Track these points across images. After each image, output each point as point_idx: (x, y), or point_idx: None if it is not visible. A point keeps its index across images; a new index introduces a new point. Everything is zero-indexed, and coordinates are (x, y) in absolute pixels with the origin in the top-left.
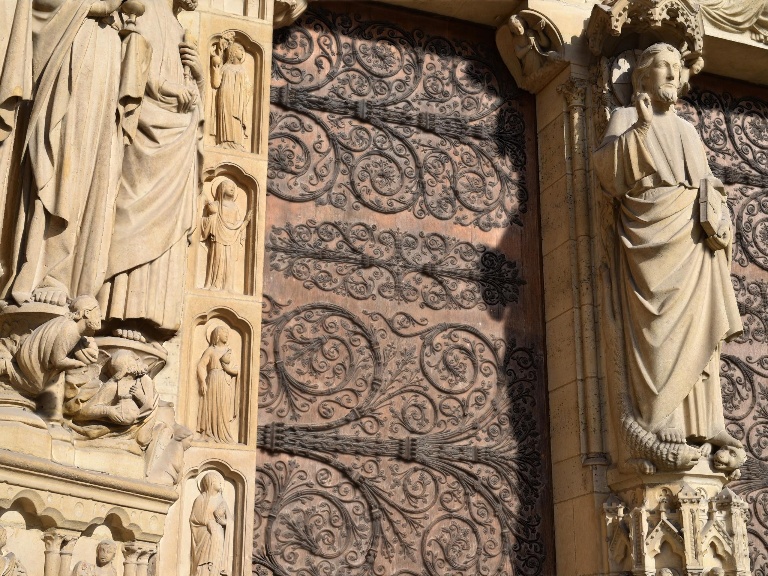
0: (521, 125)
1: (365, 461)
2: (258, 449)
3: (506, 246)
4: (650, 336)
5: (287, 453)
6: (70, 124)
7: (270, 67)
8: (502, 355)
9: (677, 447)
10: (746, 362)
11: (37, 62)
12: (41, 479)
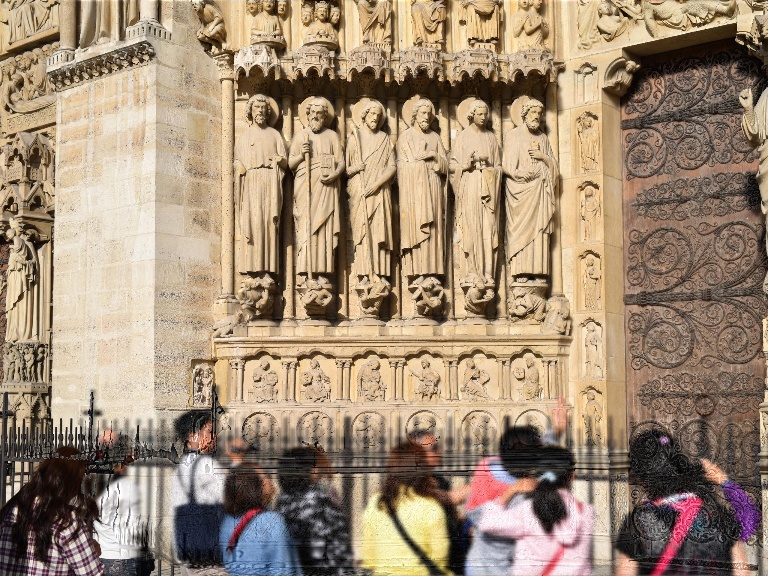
0: None
1: (686, 303)
2: (637, 305)
3: None
4: None
5: (649, 305)
6: (463, 216)
7: (602, 125)
8: (761, 233)
9: None
10: None
11: None
12: (482, 342)
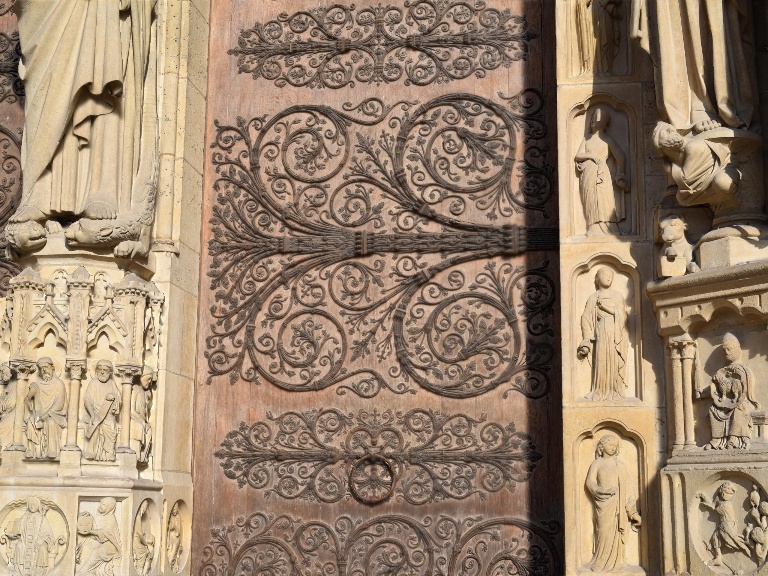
0: None
1: None
2: None
3: None
4: (25, 105)
5: None
6: None
7: None
8: None
9: (15, 227)
10: (342, 110)
11: None
12: None
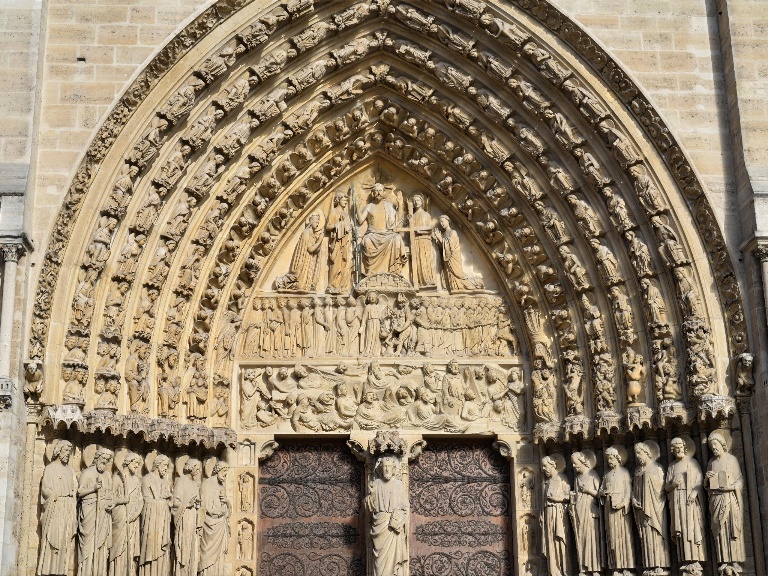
0: (360, 474)
1: None
2: None
3: (352, 522)
4: None
5: None
6: (184, 539)
7: (257, 482)
8: (350, 563)
9: None
10: (449, 554)
11: (175, 522)
12: None
